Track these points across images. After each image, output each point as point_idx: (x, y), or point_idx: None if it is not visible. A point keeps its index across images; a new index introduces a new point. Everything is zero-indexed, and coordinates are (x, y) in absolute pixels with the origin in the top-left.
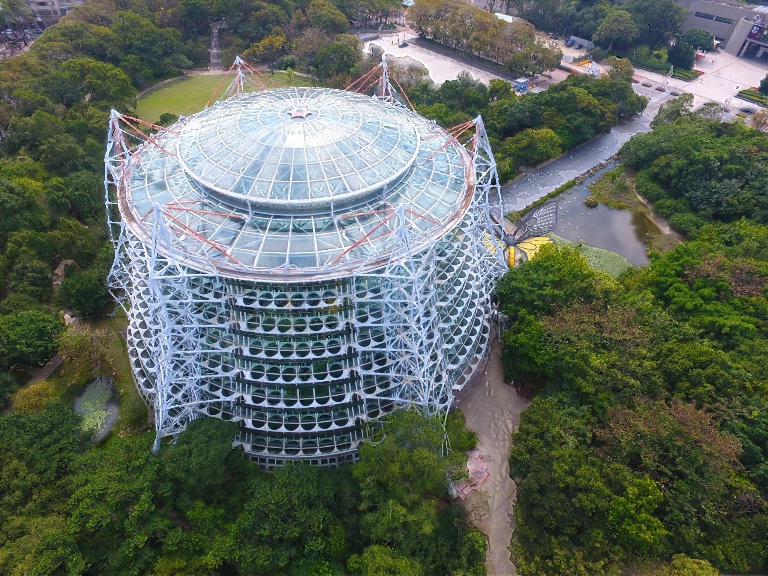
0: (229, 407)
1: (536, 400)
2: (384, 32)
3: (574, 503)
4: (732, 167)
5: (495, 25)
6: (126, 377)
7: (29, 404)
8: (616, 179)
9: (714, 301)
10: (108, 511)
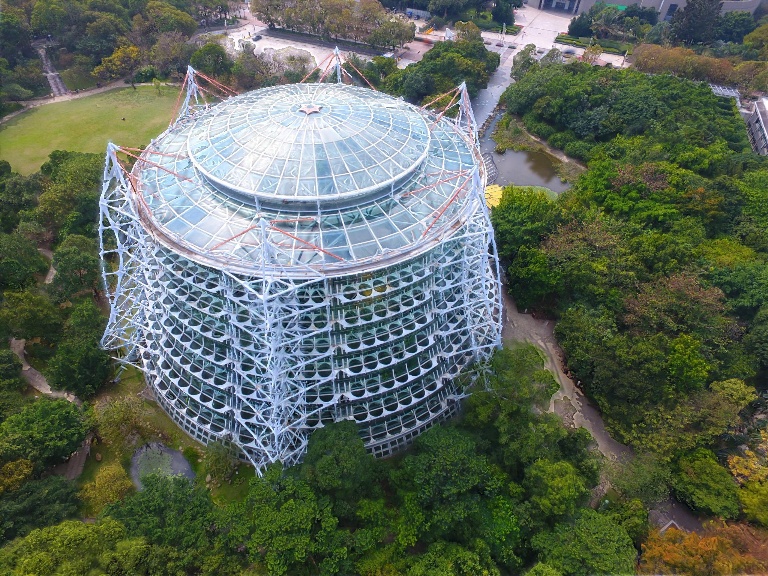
0: (325, 413)
1: (569, 312)
2: (229, 28)
3: (643, 373)
4: (597, 97)
5: (346, 6)
6: (176, 434)
7: (113, 492)
8: (509, 126)
9: (640, 200)
10: (306, 538)
